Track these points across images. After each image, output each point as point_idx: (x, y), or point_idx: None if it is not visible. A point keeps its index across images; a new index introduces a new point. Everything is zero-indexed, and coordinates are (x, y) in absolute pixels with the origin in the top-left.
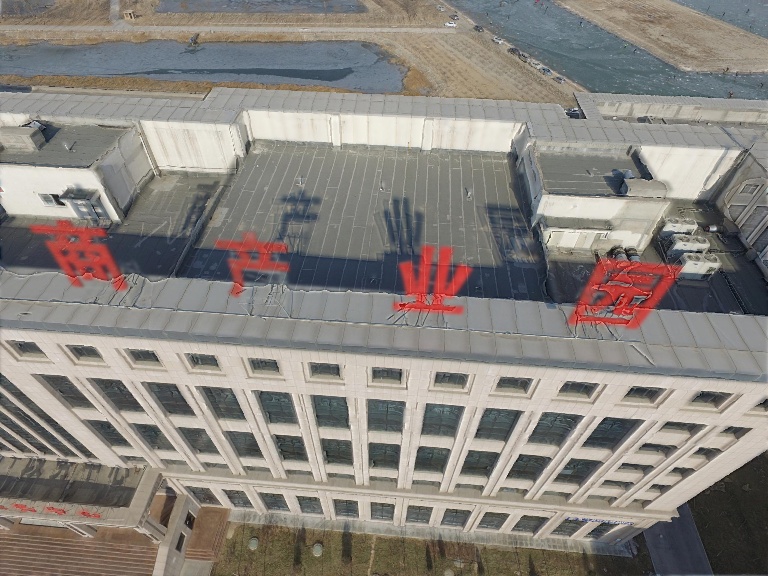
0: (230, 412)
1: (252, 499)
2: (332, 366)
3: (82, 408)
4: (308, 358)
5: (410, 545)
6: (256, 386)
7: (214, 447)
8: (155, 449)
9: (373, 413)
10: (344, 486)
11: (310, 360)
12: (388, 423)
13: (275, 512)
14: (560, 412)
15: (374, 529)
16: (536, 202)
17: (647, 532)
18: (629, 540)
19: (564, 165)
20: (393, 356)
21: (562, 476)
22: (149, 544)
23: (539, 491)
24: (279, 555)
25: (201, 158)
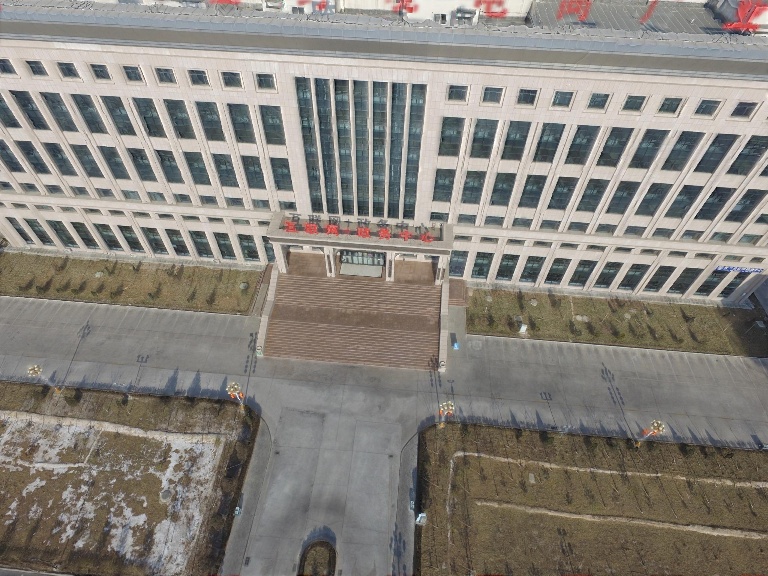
0: (543, 155)
1: (494, 263)
2: (638, 101)
3: (445, 156)
4: (634, 89)
5: (597, 301)
6: (583, 120)
7: (504, 198)
8: (461, 203)
9: (639, 148)
10: (578, 234)
11: (634, 91)
12: (642, 160)
13: (498, 282)
14: (763, 134)
15: (570, 292)
16: (750, 13)
17: (759, 298)
18: (748, 301)
19: (756, 0)
20: (685, 85)
21: (732, 214)
22: (432, 285)
23: (712, 230)
24: (508, 304)
25: (507, 5)
